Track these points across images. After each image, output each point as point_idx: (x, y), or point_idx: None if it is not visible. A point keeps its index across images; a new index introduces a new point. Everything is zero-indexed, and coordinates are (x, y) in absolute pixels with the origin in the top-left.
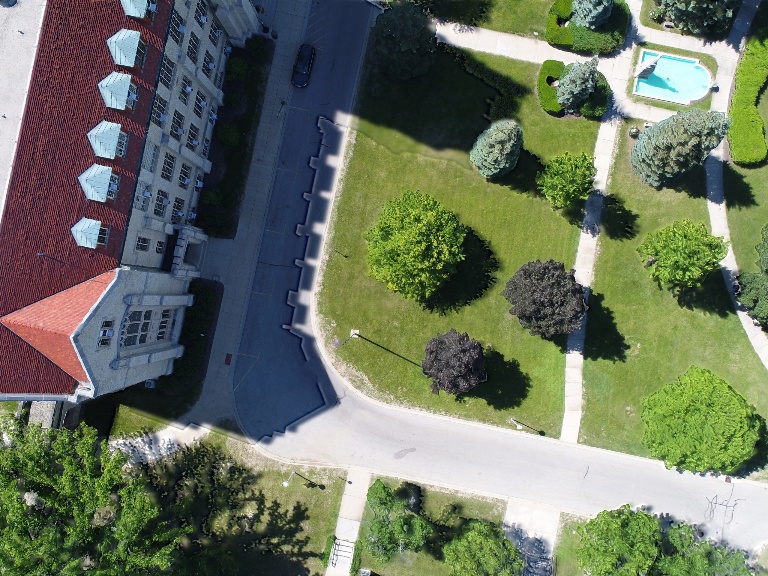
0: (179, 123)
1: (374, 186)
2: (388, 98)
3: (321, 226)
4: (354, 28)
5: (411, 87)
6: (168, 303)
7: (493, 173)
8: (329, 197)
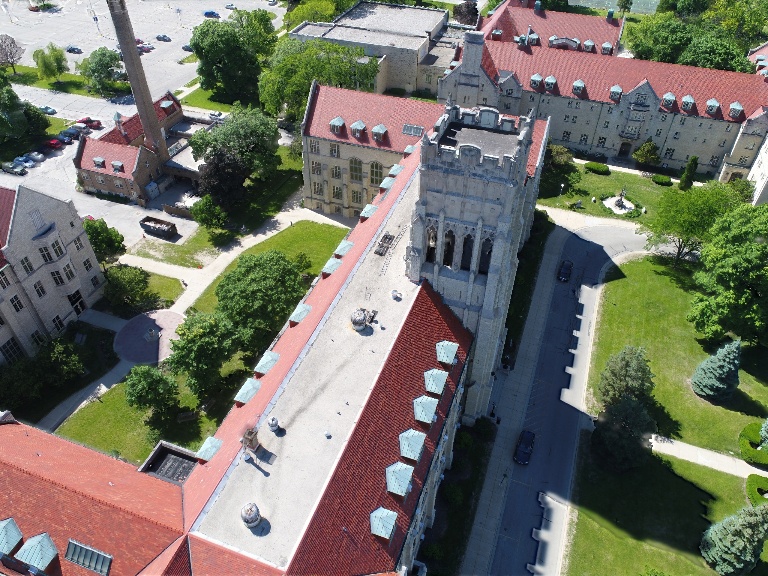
0: None
1: (602, 568)
2: (605, 486)
3: None
4: (566, 426)
5: (625, 479)
6: None
7: (733, 570)
8: (554, 572)
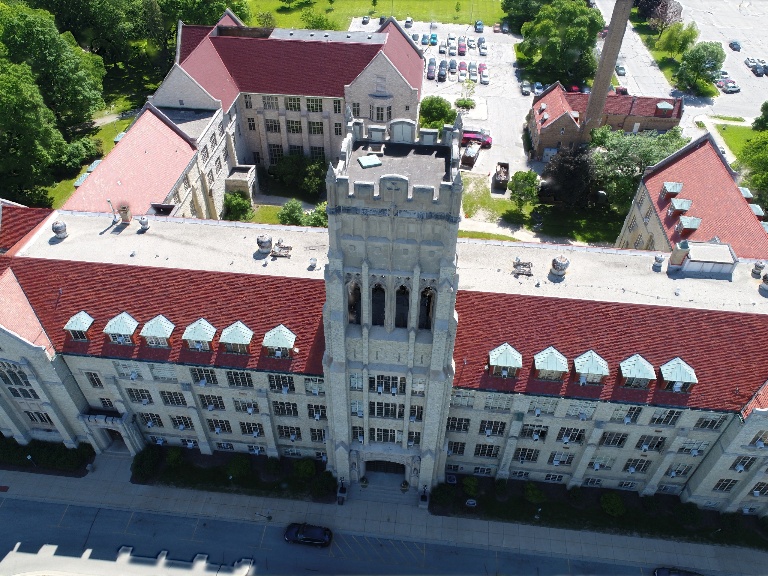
0: (218, 405)
1: None
2: None
3: (125, 575)
4: None
5: None
6: (49, 413)
7: None
8: None
